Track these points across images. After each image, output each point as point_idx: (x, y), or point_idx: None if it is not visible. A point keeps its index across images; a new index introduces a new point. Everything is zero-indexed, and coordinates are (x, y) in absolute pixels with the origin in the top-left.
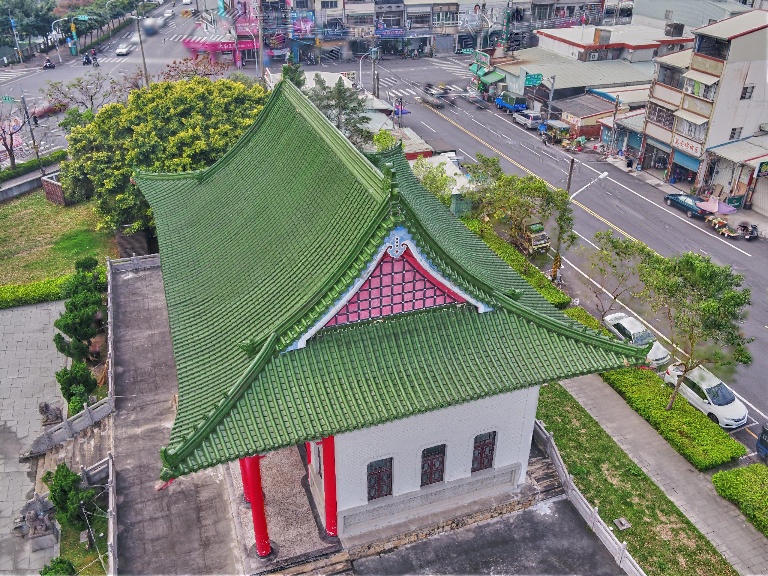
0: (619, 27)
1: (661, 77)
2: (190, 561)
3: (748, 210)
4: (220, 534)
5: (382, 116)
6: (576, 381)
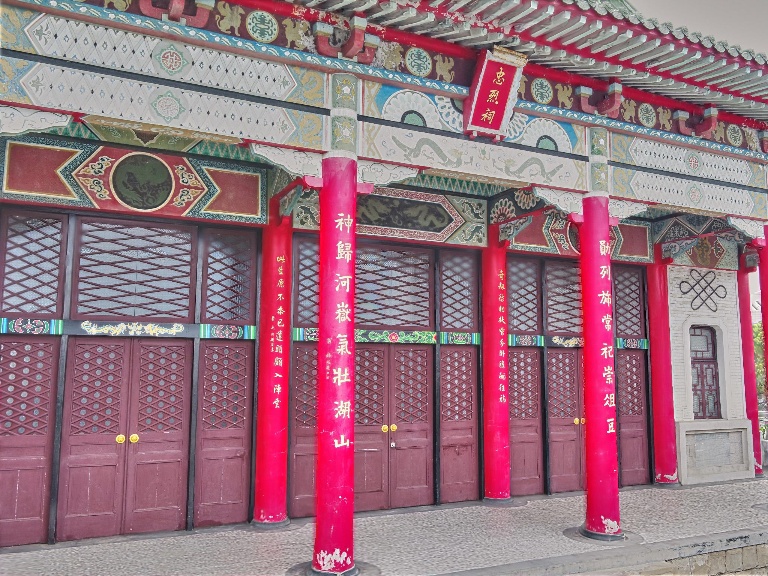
0: None
1: None
2: None
3: None
4: None
5: None
6: None
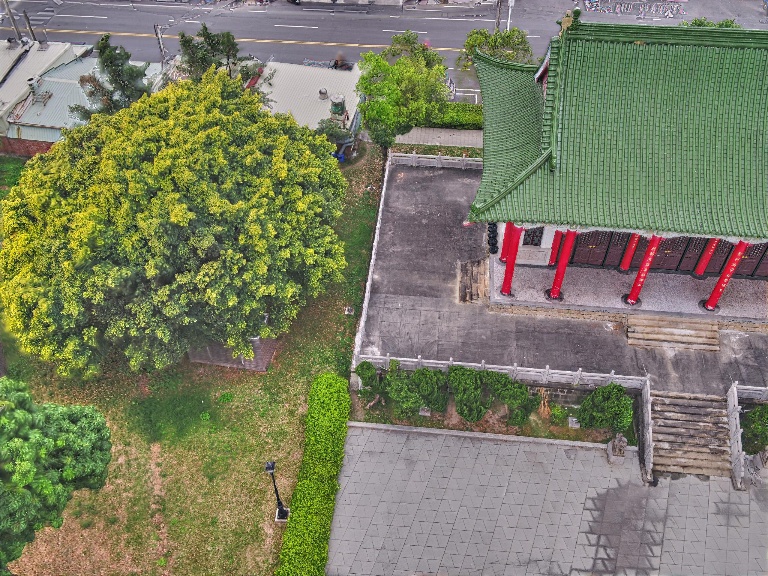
0: None
1: None
2: None
3: None
4: None
5: None
6: None
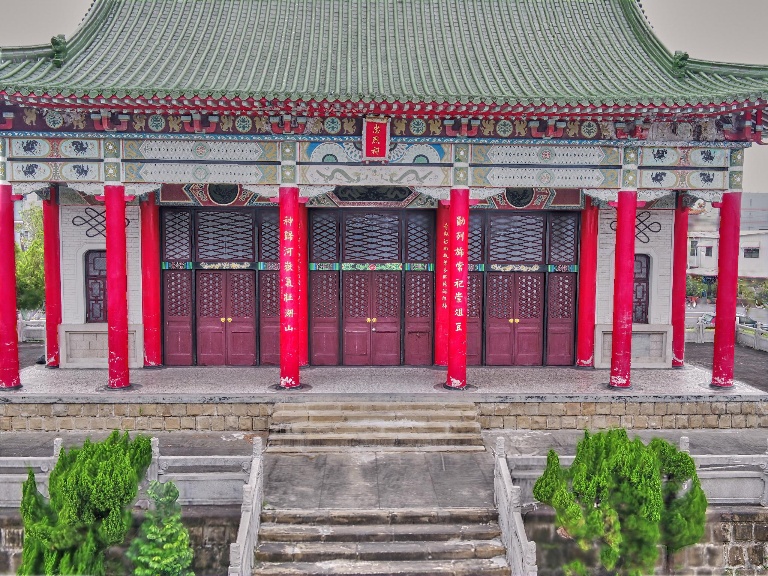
0: None
1: None
2: None
3: None
4: (667, 437)
5: None
6: None
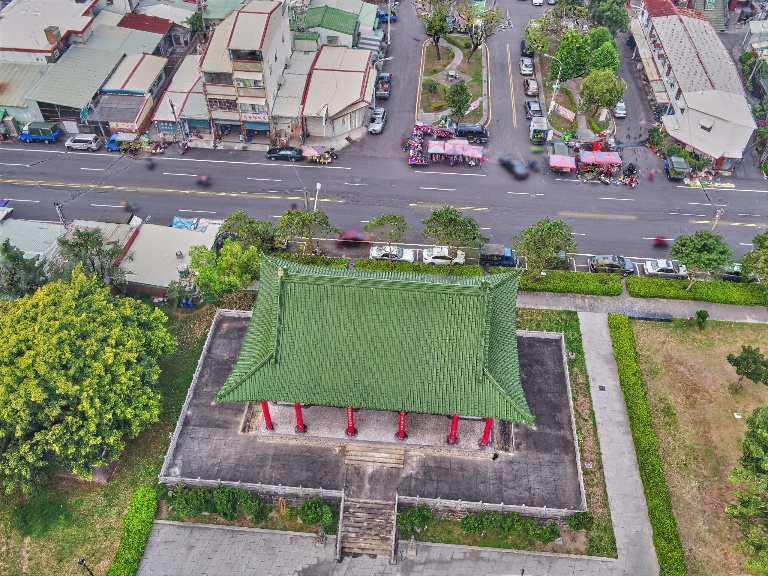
0: (22, 6)
1: (207, 79)
2: (469, 477)
3: (309, 137)
4: (458, 462)
5: (16, 223)
6: None
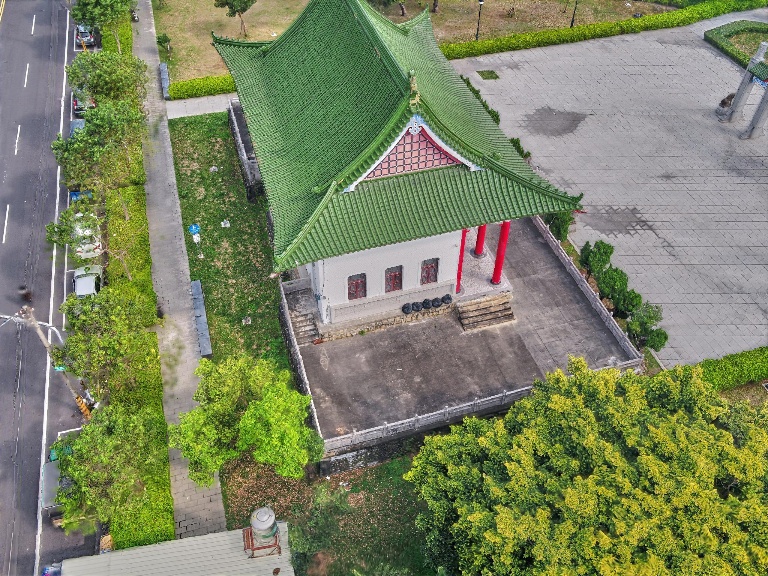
0: None
1: None
2: None
3: None
4: None
5: None
6: (173, 259)
